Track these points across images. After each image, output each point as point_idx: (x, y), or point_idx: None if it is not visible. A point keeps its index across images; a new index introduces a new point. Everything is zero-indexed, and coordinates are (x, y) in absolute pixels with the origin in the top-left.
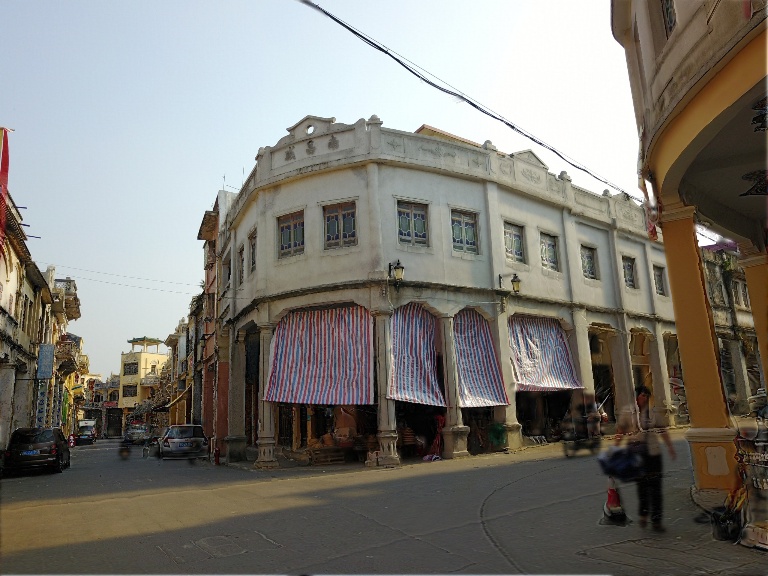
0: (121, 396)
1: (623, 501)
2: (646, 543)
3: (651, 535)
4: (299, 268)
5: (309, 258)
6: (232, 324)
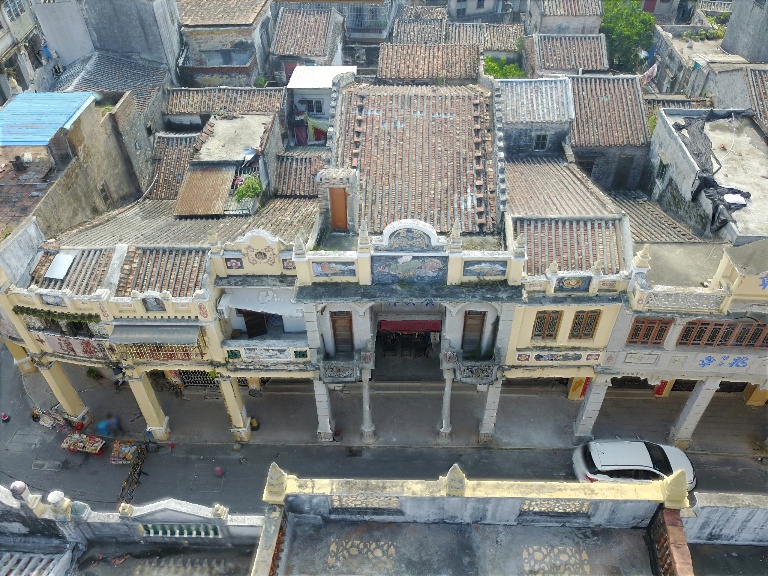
0: None
1: (2, 394)
2: (19, 433)
3: (19, 425)
4: None
5: None
6: None
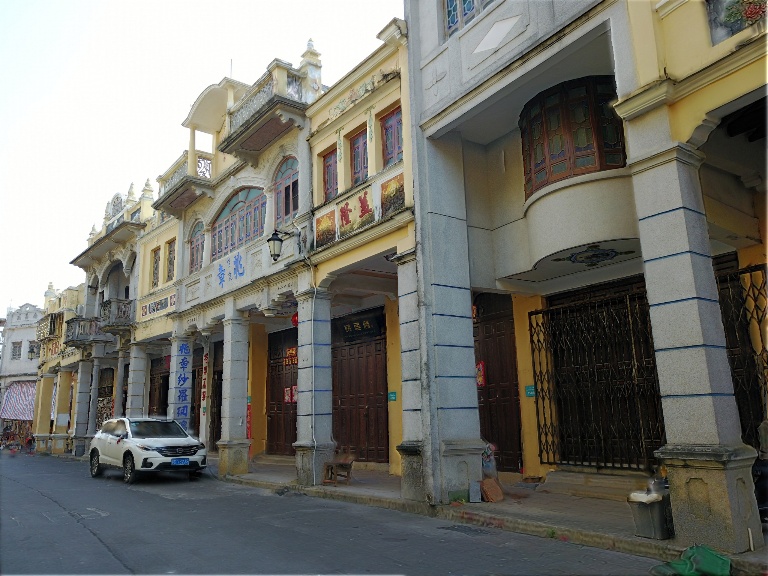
0: None
1: None
2: None
3: None
4: (17, 365)
5: (21, 362)
6: None
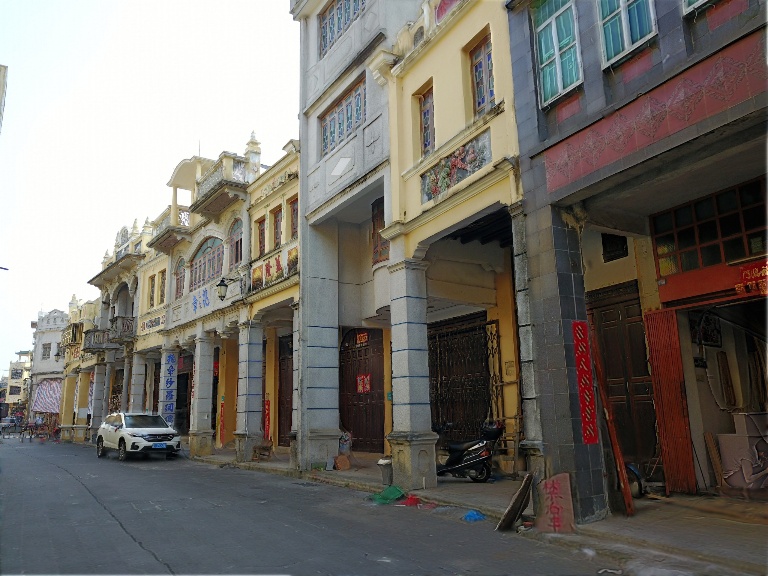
0: (8, 394)
1: None
2: None
3: None
4: (47, 364)
5: (51, 361)
6: (31, 378)
